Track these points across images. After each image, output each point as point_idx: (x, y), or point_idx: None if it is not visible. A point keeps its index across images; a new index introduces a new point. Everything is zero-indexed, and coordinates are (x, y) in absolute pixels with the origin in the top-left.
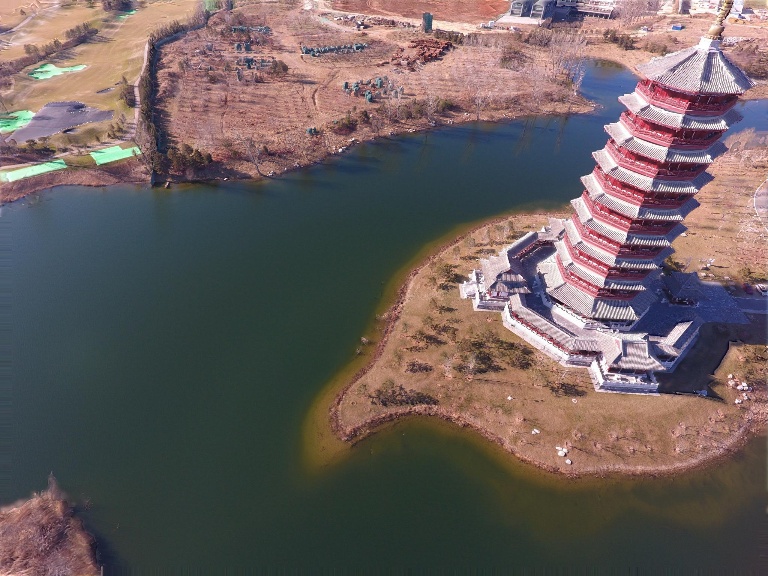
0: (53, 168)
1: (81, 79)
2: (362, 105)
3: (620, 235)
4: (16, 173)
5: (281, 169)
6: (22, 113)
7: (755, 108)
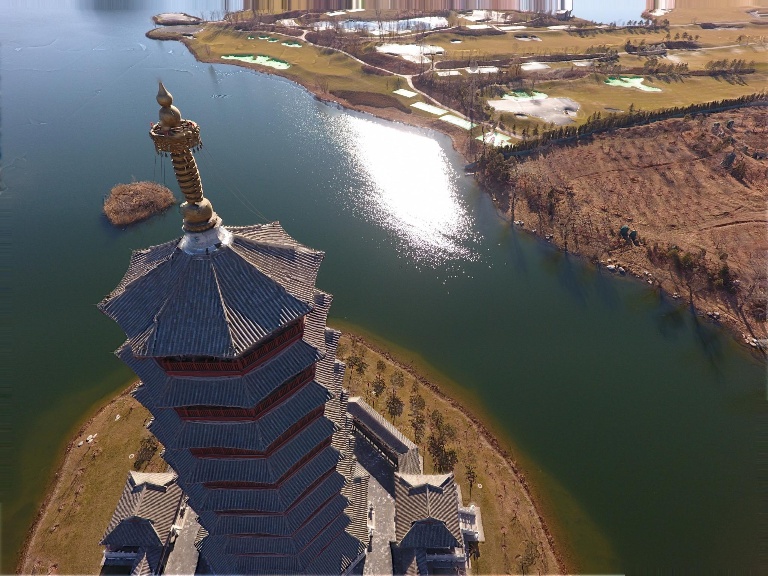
0: (464, 126)
1: (627, 96)
2: (767, 270)
3: None
4: (451, 117)
5: (532, 227)
6: (542, 95)
7: None
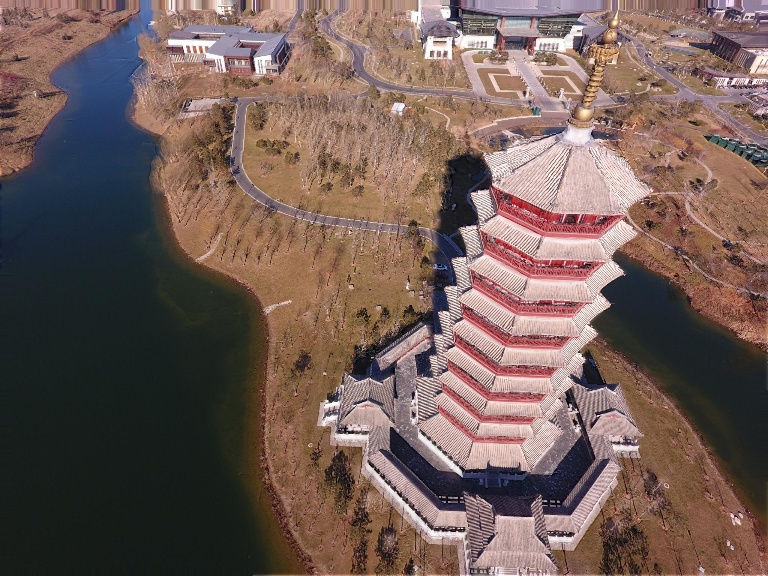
0: None
1: None
2: None
3: (573, 359)
4: None
5: None
6: None
7: (51, 135)
